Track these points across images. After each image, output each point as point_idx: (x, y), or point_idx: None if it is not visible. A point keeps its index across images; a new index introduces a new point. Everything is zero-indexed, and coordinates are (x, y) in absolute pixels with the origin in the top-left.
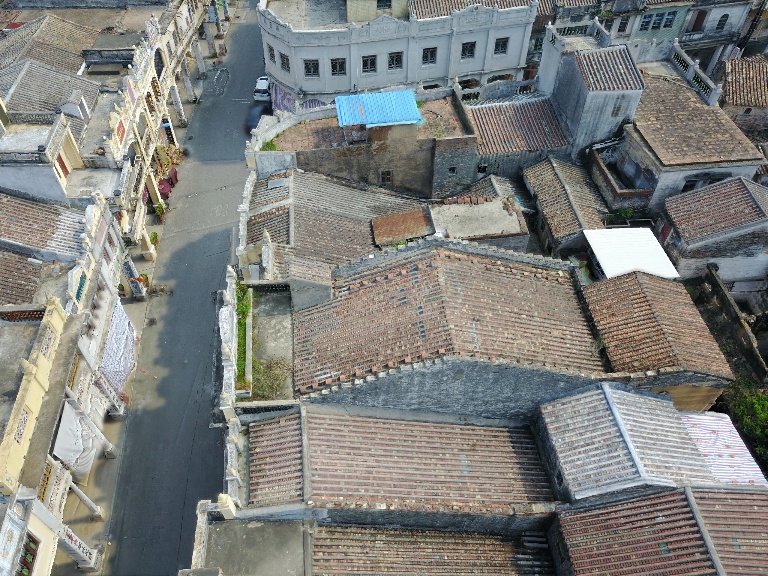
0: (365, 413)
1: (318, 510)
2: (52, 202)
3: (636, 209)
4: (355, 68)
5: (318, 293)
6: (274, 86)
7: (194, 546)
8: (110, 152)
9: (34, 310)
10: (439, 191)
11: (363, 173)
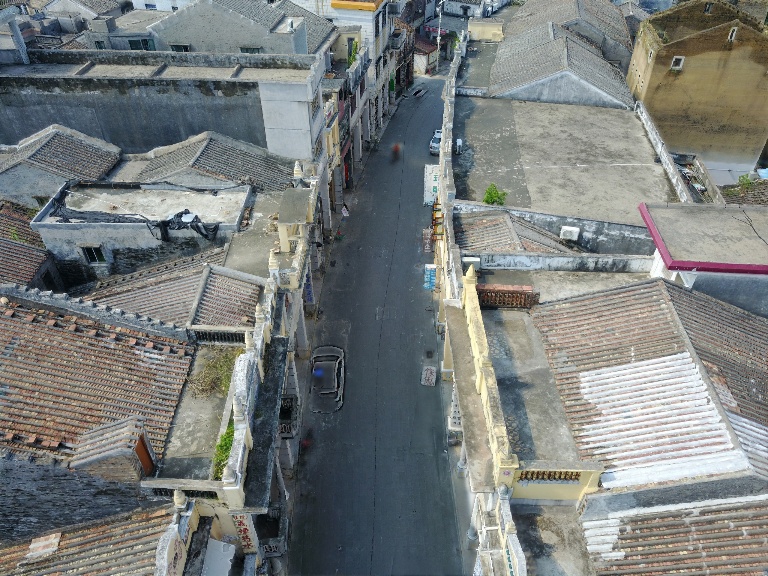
0: None
1: None
2: None
3: None
4: None
5: None
6: None
7: None
8: None
9: None
10: None
11: None
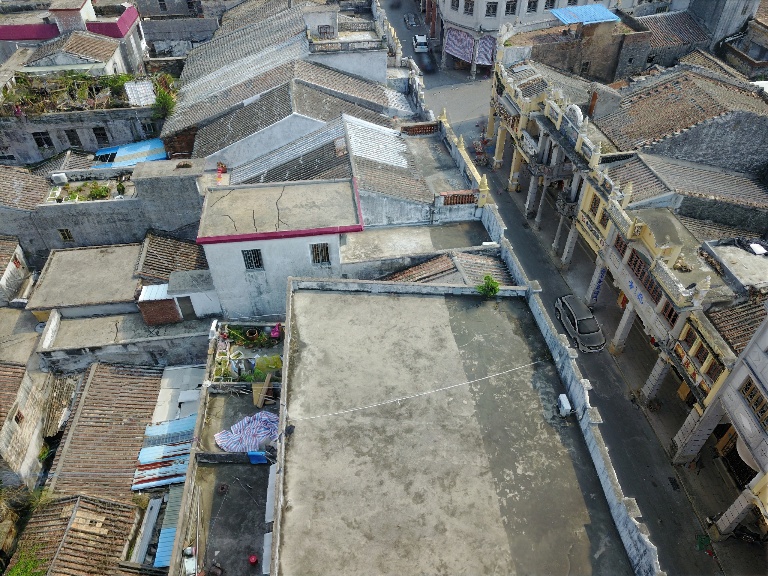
0: (672, 162)
1: (679, 197)
2: (376, 83)
3: (766, 77)
4: (523, 8)
5: (613, 104)
6: (448, 32)
7: (621, 212)
8: (399, 53)
9: (429, 124)
10: (619, 79)
11: (571, 64)
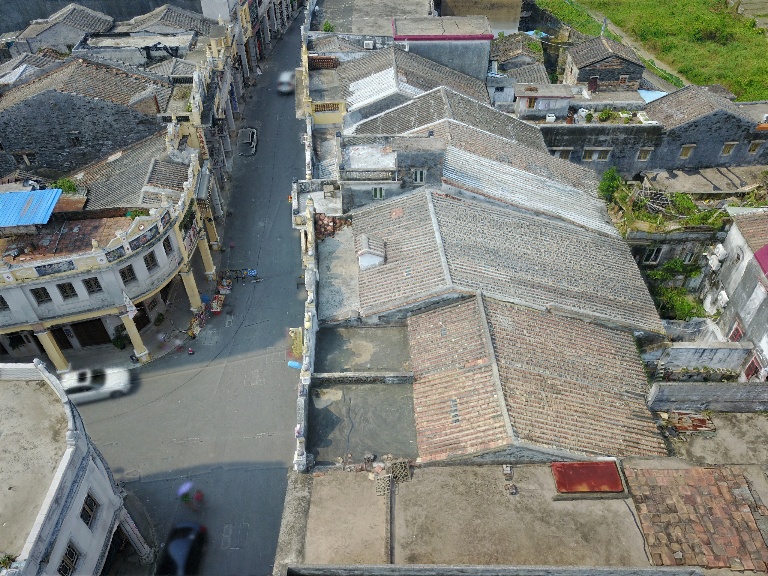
0: None
1: None
2: None
3: None
4: None
5: None
6: None
7: None
8: None
9: None
10: None
11: None
